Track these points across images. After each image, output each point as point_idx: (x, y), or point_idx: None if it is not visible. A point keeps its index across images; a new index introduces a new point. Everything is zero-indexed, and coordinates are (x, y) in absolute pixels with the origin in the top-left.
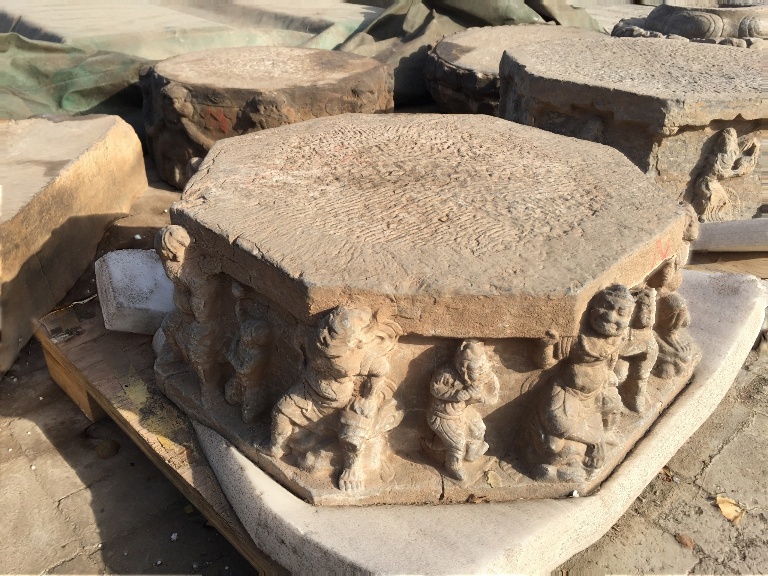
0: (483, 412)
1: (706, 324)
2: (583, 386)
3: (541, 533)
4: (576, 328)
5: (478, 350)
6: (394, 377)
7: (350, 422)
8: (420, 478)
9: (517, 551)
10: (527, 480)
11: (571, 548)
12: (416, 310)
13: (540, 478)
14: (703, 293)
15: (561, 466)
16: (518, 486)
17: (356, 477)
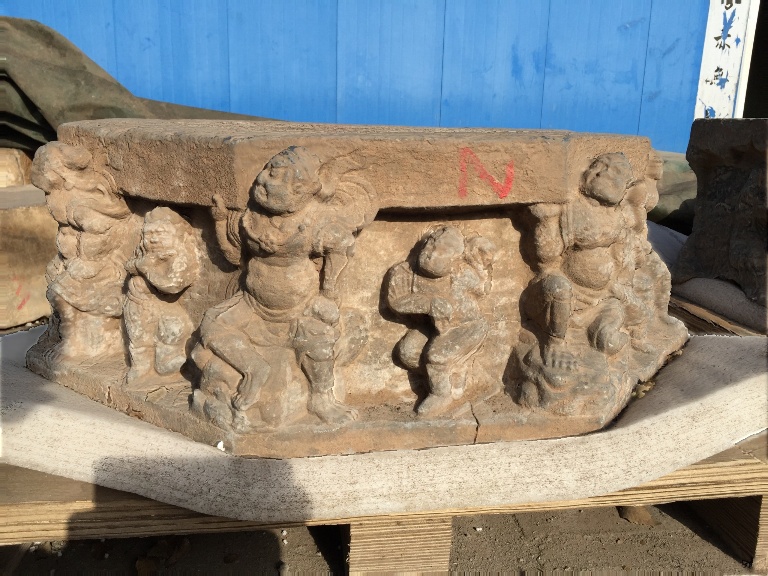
0: (195, 322)
1: (693, 384)
2: (253, 289)
3: (73, 418)
4: (242, 197)
5: (157, 213)
6: (130, 256)
7: (57, 276)
8: (107, 372)
9: (4, 402)
10: (184, 408)
11: (129, 479)
12: (119, 159)
13: (191, 407)
14: (740, 357)
15: (210, 396)
16: (169, 410)
17: (60, 349)
